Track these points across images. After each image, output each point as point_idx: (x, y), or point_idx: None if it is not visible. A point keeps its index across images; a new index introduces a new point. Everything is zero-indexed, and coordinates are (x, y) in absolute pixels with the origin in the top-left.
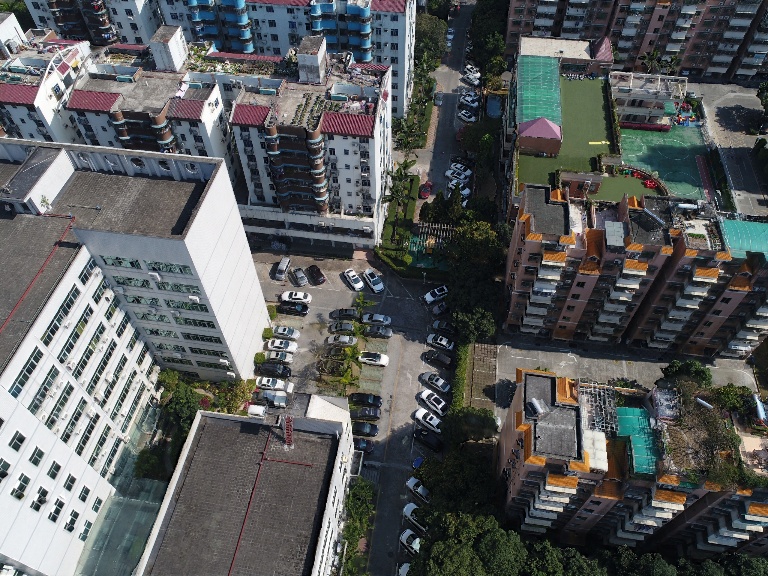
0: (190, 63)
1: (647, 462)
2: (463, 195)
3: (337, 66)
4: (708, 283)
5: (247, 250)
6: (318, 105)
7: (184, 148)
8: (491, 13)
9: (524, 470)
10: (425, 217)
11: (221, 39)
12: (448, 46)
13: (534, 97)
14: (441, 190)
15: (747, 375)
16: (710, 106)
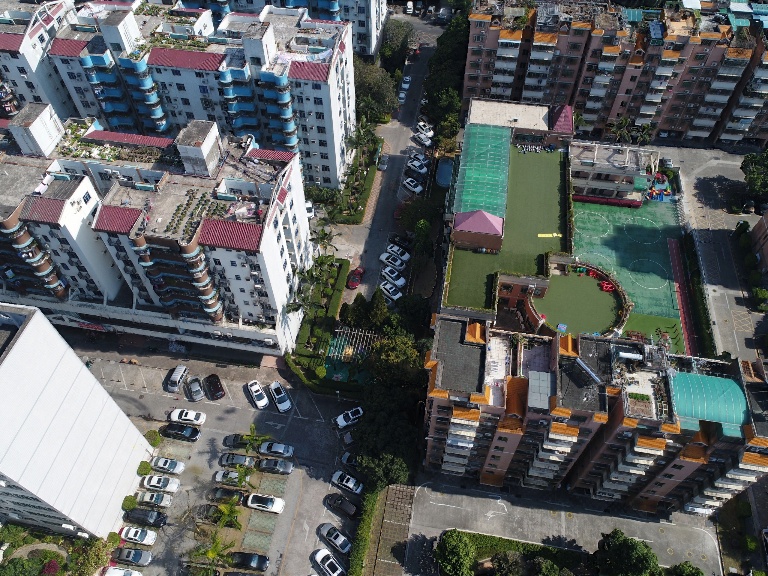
0: (63, 146)
1: None
2: (397, 286)
3: (231, 155)
4: (653, 455)
5: (98, 392)
6: (201, 207)
7: (50, 249)
8: (447, 64)
9: None
10: (345, 319)
11: (127, 101)
12: (401, 98)
13: (477, 178)
14: (373, 278)
15: (709, 536)
16: (689, 176)
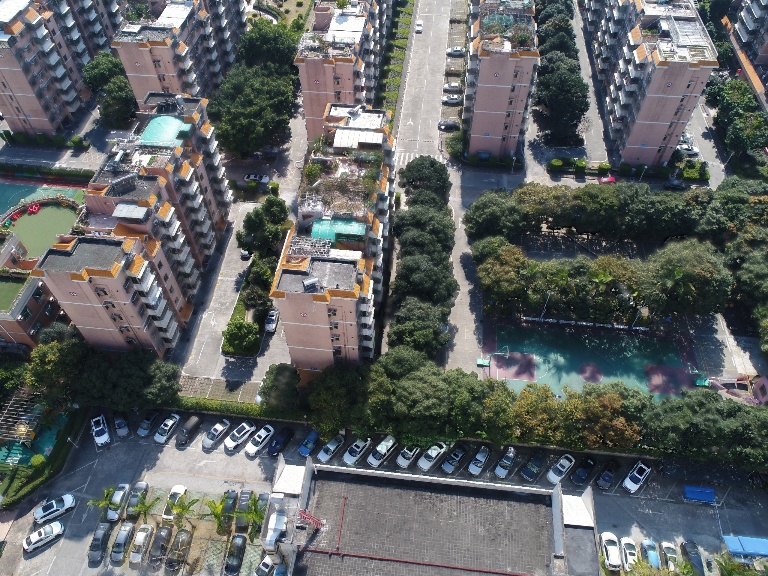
0: None
1: (357, 227)
2: None
3: None
4: None
5: None
6: None
7: None
8: None
9: (354, 312)
10: None
11: None
12: None
13: None
14: None
15: (245, 206)
16: None
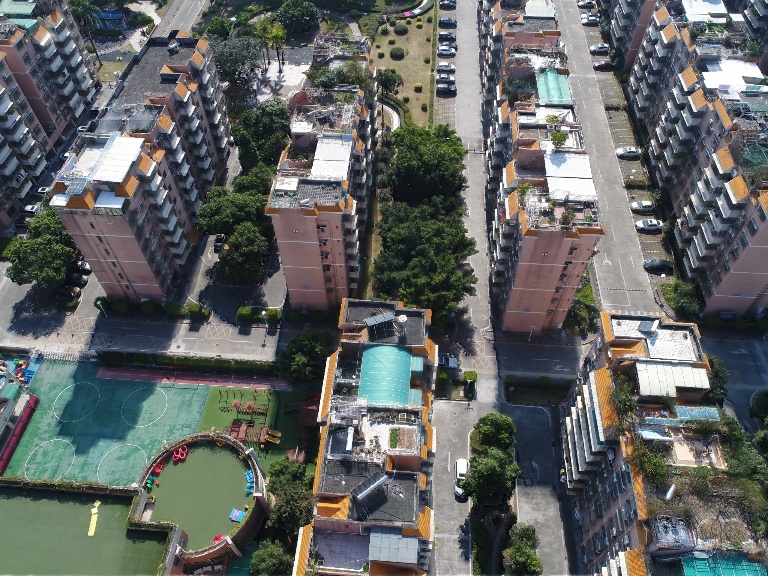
0: None
1: (753, 572)
2: None
3: None
4: None
5: None
6: None
7: None
8: None
9: None
10: None
11: None
12: None
13: None
14: None
15: (436, 406)
16: (3, 337)
